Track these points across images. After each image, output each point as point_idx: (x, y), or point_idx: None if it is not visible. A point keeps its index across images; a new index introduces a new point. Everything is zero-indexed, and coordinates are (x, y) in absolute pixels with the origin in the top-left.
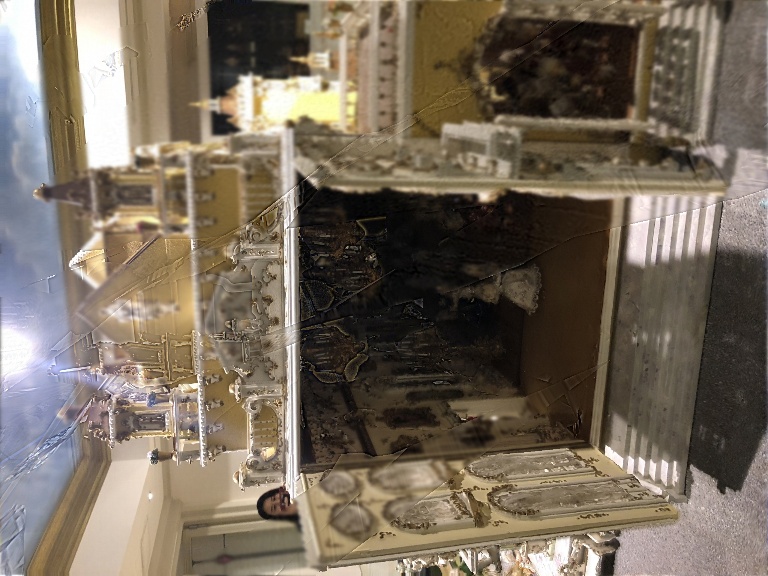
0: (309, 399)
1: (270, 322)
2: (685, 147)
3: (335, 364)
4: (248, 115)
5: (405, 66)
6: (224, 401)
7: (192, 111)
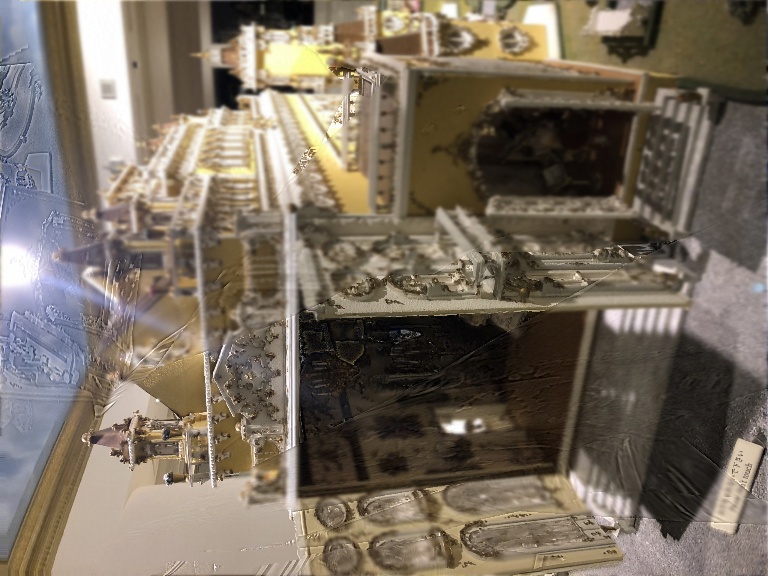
0: (307, 403)
1: (272, 374)
2: (616, 450)
3: (331, 388)
4: (258, 490)
5: (383, 451)
6: (231, 434)
7: (215, 497)
